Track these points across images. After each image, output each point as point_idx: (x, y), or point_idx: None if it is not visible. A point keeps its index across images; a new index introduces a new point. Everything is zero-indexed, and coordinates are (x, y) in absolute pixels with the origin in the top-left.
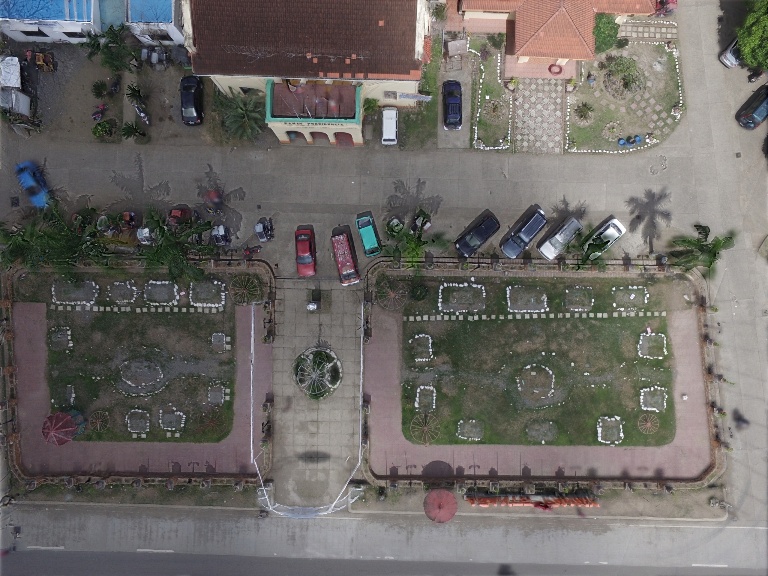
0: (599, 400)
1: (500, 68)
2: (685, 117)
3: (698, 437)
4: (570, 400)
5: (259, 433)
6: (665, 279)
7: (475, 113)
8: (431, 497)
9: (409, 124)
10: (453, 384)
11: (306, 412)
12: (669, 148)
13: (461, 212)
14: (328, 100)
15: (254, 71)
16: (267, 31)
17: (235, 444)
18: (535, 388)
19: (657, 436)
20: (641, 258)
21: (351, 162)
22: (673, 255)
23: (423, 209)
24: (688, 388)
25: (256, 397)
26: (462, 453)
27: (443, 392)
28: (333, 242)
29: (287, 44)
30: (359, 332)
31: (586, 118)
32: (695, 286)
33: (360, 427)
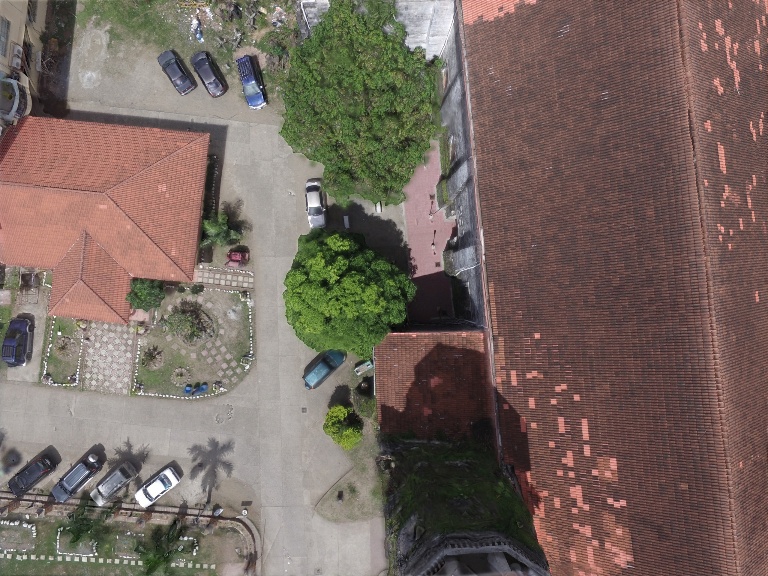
0: None
1: None
2: (255, 367)
3: None
4: None
5: None
6: (219, 531)
7: (47, 348)
8: None
9: None
10: None
11: None
12: (236, 398)
13: (25, 446)
14: None
15: None
16: None
17: None
18: None
19: None
20: (198, 507)
21: None
22: None
23: None
24: None
25: None
26: None
27: None
28: None
29: None
30: None
31: (154, 362)
32: None
33: None
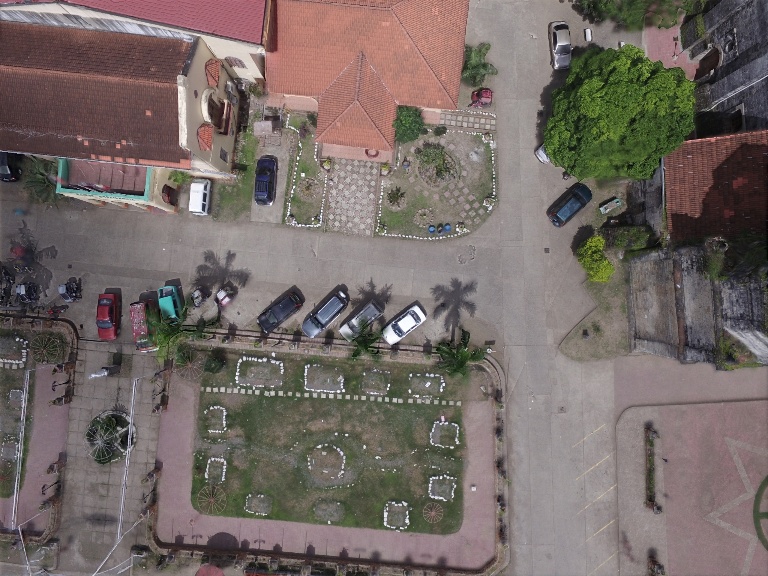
0: (388, 484)
1: (317, 147)
2: (497, 209)
3: (484, 529)
4: (360, 482)
5: (49, 492)
6: None
7: (290, 189)
8: (201, 573)
9: (224, 195)
10: (245, 458)
11: (98, 474)
12: (479, 238)
13: (268, 286)
14: (124, 173)
15: (27, 148)
16: (37, 112)
17: (25, 501)
18: (325, 468)
19: (443, 525)
20: None
21: (164, 229)
22: (441, 356)
23: (231, 281)
24: (478, 479)
25: (50, 456)
26: (249, 527)
27: (234, 465)
28: (130, 310)
29: (57, 125)
30: (157, 399)
31: (398, 203)
32: (492, 378)
33: (122, 503)
